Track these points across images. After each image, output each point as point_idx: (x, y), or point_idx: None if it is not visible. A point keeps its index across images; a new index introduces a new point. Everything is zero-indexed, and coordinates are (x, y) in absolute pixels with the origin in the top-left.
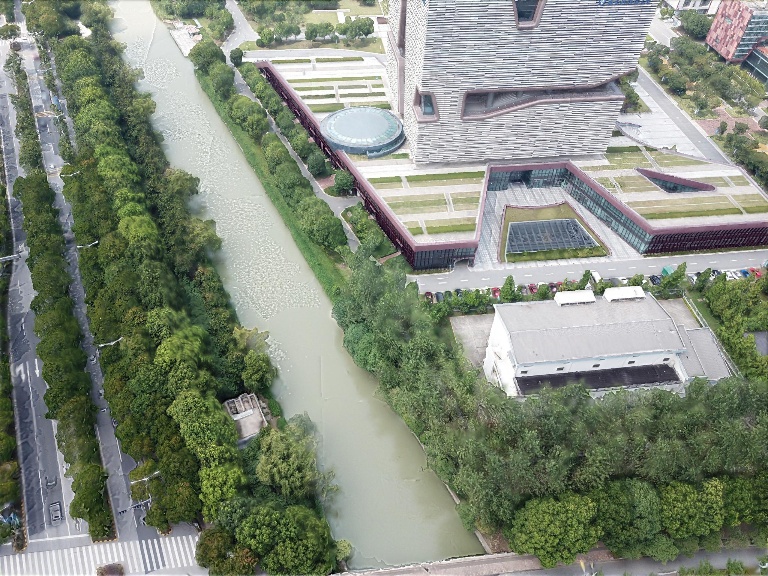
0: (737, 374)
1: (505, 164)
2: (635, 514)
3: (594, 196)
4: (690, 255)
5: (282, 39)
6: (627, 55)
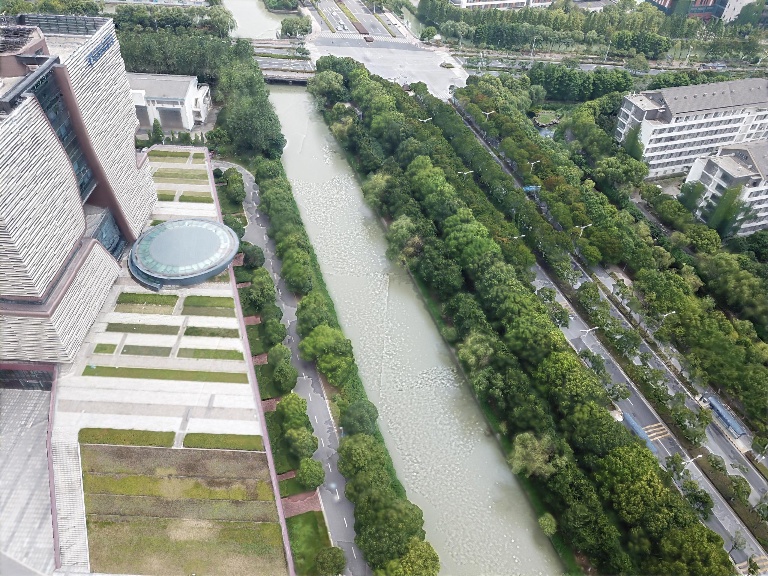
0: None
1: None
2: None
3: None
4: None
5: None
6: None
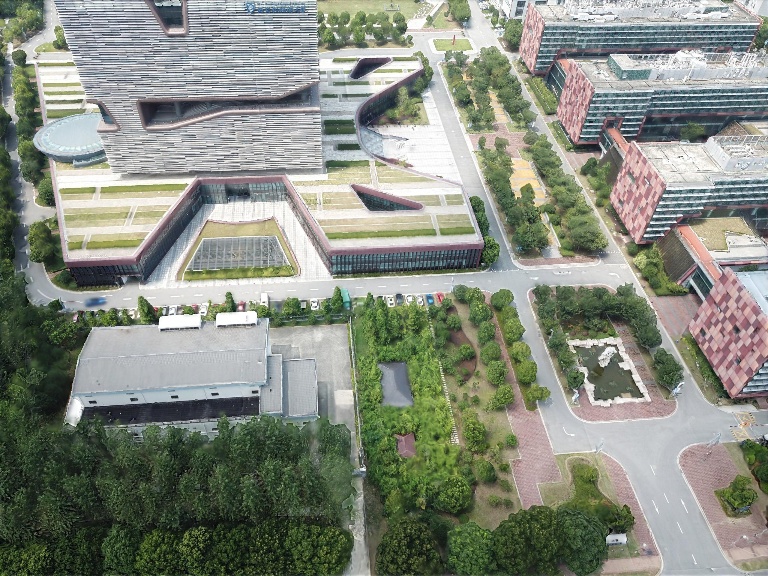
0: (357, 408)
1: (215, 176)
2: (104, 565)
3: (301, 212)
4: (384, 277)
5: None
6: (303, 66)
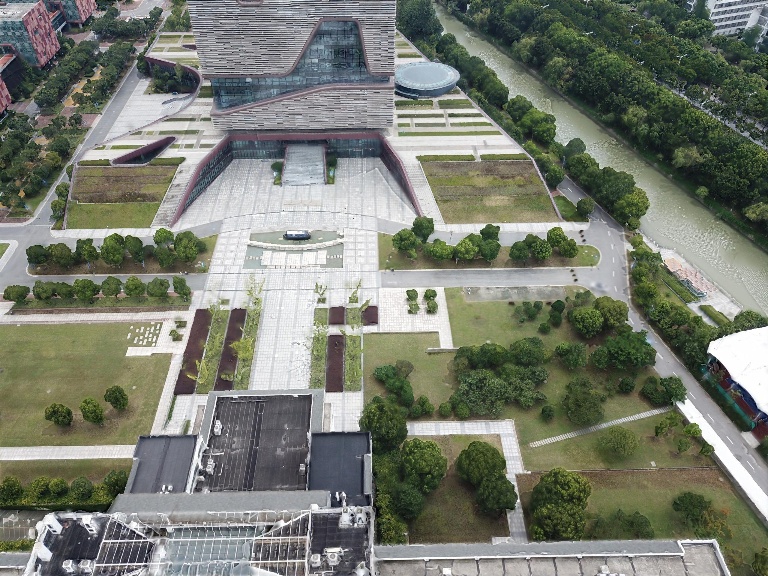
0: None
1: None
2: None
3: None
4: None
5: (539, 270)
6: None
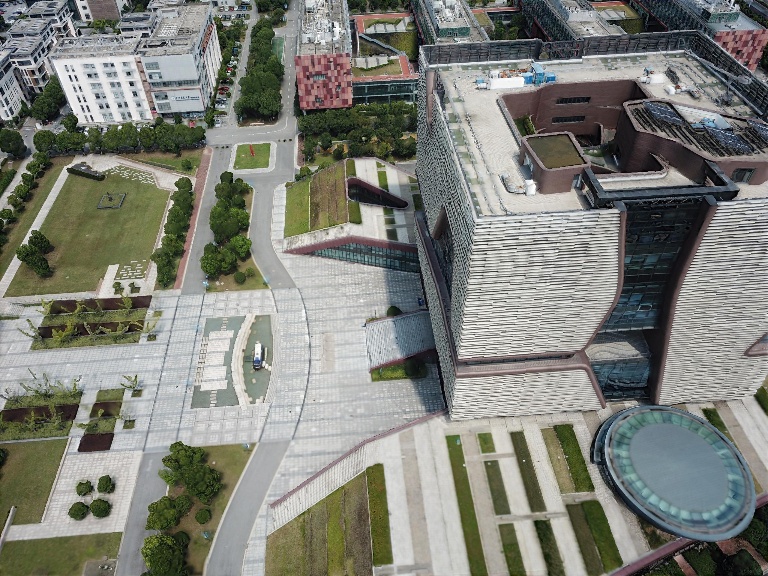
0: None
1: None
2: None
3: None
4: None
5: None
6: None
